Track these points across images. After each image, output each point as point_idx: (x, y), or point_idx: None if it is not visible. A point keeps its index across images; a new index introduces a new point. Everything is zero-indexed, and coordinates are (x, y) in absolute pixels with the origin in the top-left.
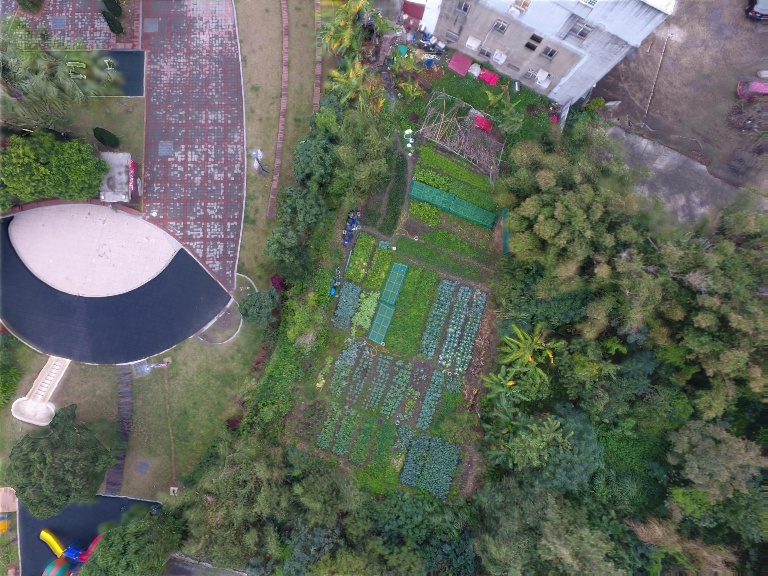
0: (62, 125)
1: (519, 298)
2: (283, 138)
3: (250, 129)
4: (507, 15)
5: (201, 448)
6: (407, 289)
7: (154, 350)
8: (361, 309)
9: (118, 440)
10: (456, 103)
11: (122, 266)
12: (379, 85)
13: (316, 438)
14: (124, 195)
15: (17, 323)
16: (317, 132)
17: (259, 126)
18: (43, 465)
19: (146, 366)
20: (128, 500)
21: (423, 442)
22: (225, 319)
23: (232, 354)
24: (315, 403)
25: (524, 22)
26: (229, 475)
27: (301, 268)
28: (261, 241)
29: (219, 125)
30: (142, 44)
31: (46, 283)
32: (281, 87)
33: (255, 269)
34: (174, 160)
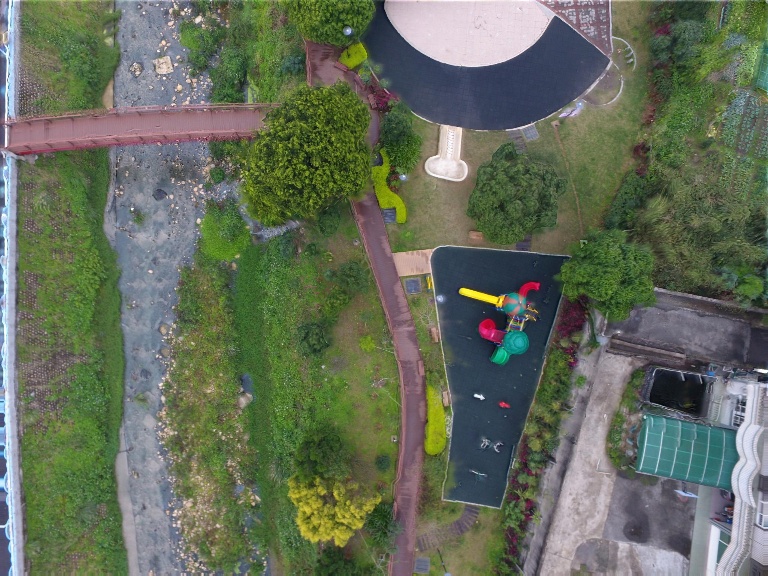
0: None
1: None
2: None
3: None
4: None
5: (604, 202)
6: None
7: (541, 114)
8: (745, 59)
9: None
10: None
11: (499, 36)
12: None
13: None
14: None
15: (405, 95)
16: None
17: None
18: (529, 175)
19: (535, 130)
20: (540, 255)
21: None
22: (605, 82)
23: (620, 113)
24: (708, 154)
25: None
26: (686, 192)
27: (710, 5)
28: (631, 5)
29: None
30: None
31: (428, 56)
32: None
33: (629, 32)
34: None
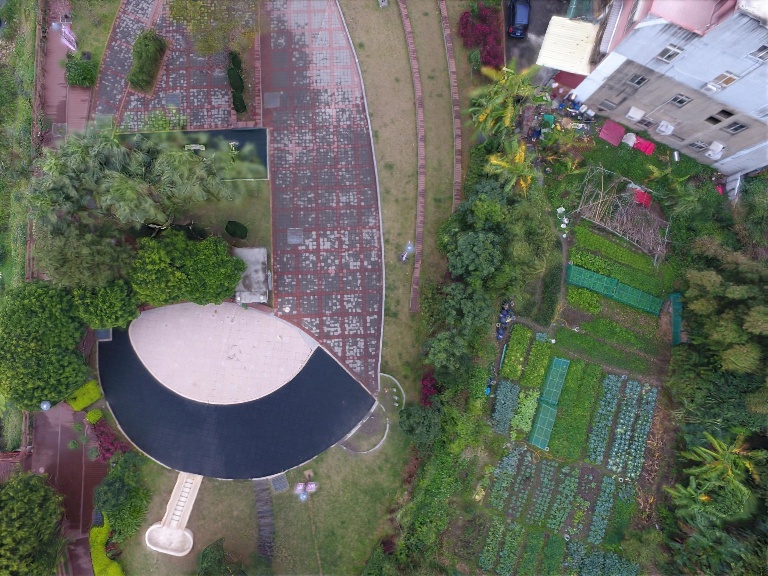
0: (182, 214)
1: (704, 399)
2: (423, 221)
3: (386, 211)
4: (697, 92)
5: (352, 573)
6: (570, 386)
7: (293, 462)
8: (522, 411)
9: (261, 567)
10: (615, 179)
11: (254, 368)
12: (526, 159)
13: (478, 557)
14: (262, 295)
15: (142, 436)
16: (475, 221)
17: (395, 208)
18: None
19: (285, 480)
20: None
21: (597, 559)
22: (369, 424)
23: (380, 464)
24: (475, 518)
25: (715, 99)
26: None
27: (466, 375)
28: (405, 336)
29: (352, 208)
30: (263, 121)
31: (172, 390)
32: (417, 164)
33: (400, 368)
34: (305, 248)
